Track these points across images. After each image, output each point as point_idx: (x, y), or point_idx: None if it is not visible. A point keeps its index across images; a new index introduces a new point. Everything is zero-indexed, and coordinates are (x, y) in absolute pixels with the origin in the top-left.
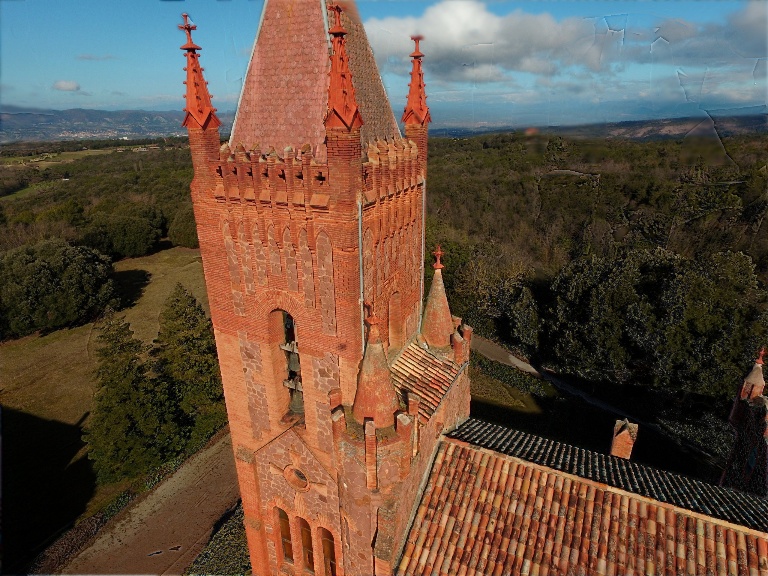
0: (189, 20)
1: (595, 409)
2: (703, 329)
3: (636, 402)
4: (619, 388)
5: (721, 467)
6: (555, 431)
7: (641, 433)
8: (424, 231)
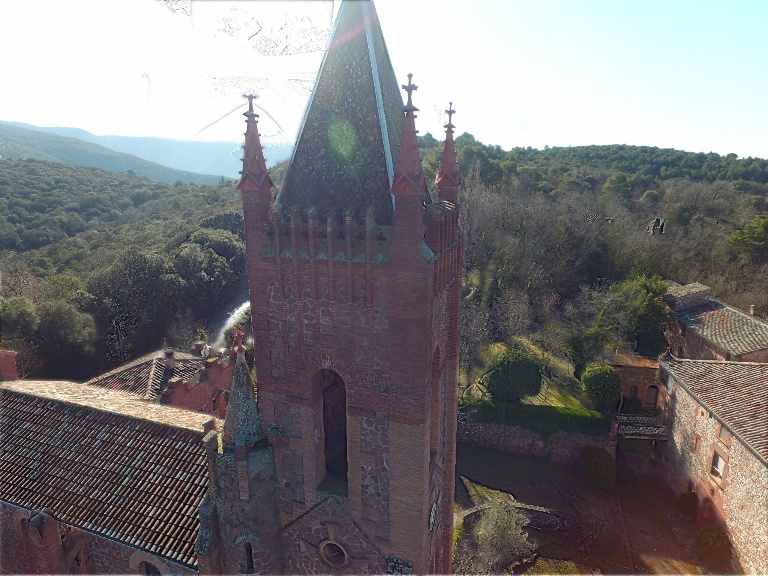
0: (448, 106)
1: None
2: None
3: None
4: None
5: None
6: None
7: None
8: (253, 313)
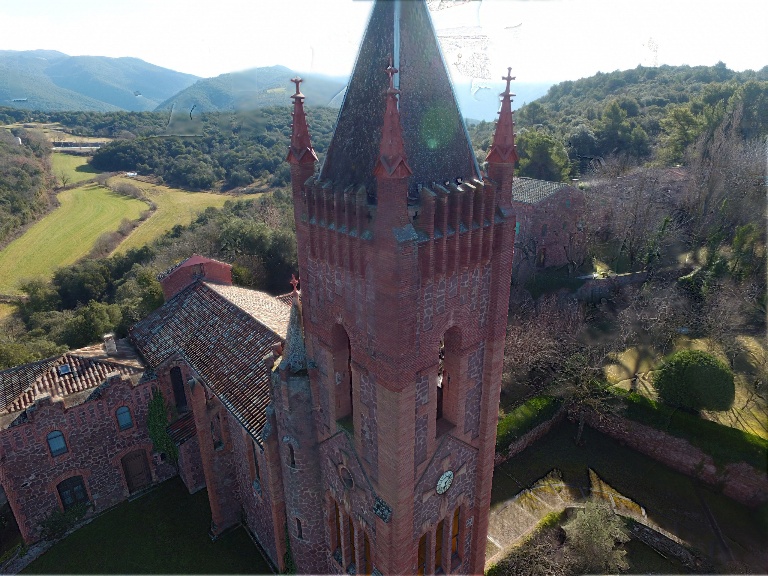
0: (507, 72)
1: None
2: None
3: None
4: None
5: None
6: None
7: None
8: None
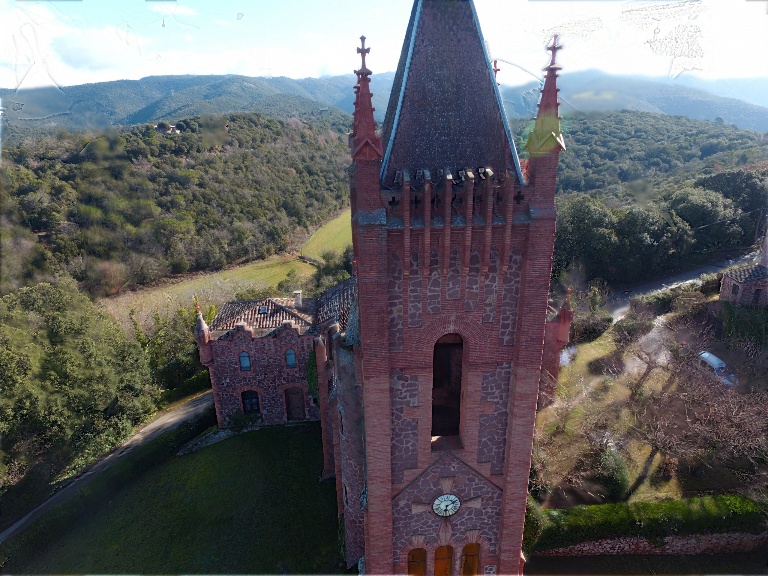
0: (553, 41)
1: (46, 520)
2: (38, 369)
3: (18, 498)
4: (1, 502)
5: (130, 448)
6: (73, 566)
7: (103, 478)
8: None
